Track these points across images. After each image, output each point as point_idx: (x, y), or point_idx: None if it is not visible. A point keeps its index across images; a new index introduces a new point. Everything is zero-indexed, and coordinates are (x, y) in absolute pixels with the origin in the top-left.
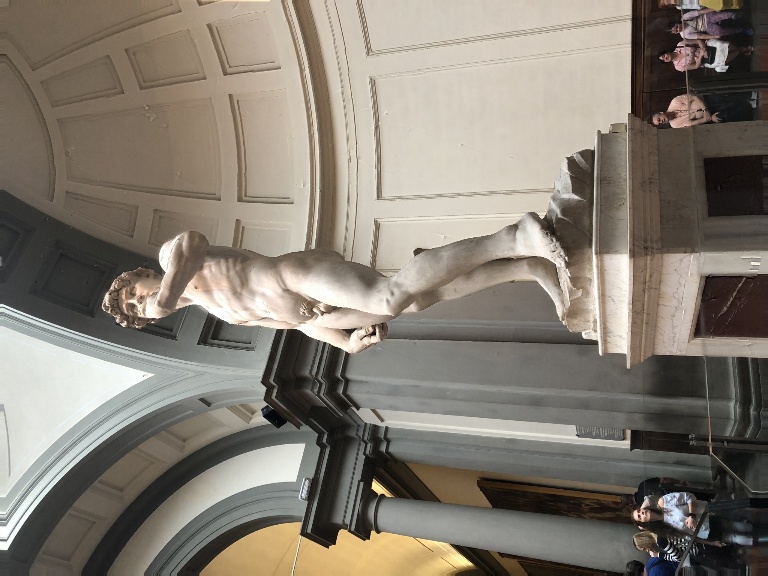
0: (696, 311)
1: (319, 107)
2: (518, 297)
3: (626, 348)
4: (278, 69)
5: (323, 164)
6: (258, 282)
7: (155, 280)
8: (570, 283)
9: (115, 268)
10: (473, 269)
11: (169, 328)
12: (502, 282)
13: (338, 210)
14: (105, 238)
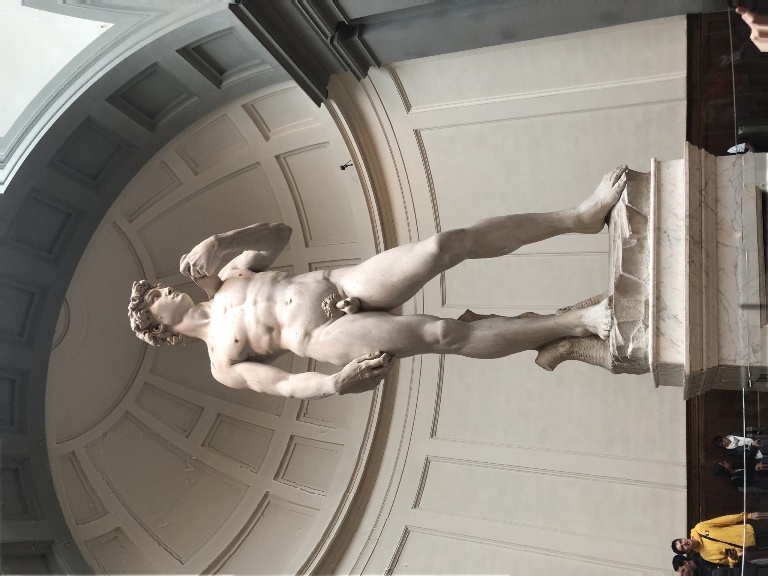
0: (761, 258)
1: (343, 531)
2: None
3: (684, 348)
4: (323, 495)
5: None
6: (303, 276)
7: None
8: (626, 214)
9: (39, 519)
10: None
11: None
12: (543, 327)
13: None
14: None
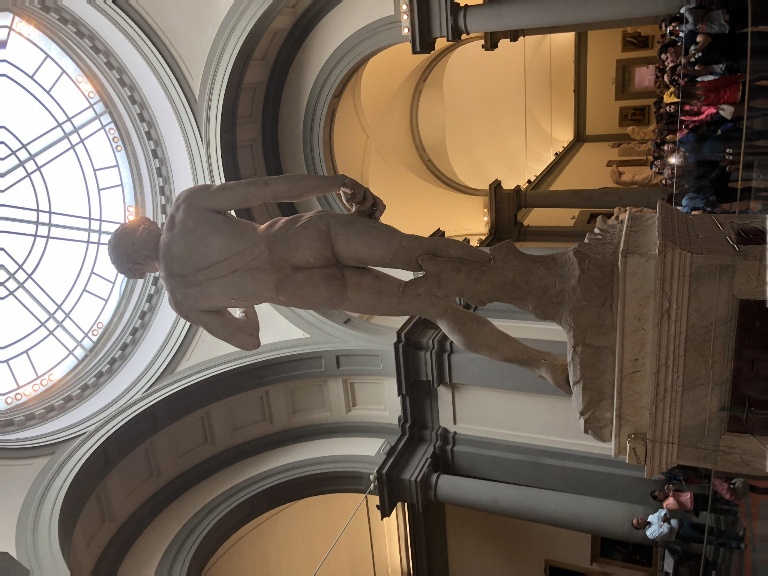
0: None
1: None
2: None
3: None
4: None
5: None
6: None
7: (146, 266)
8: None
9: None
10: None
11: None
12: None
13: None
14: None
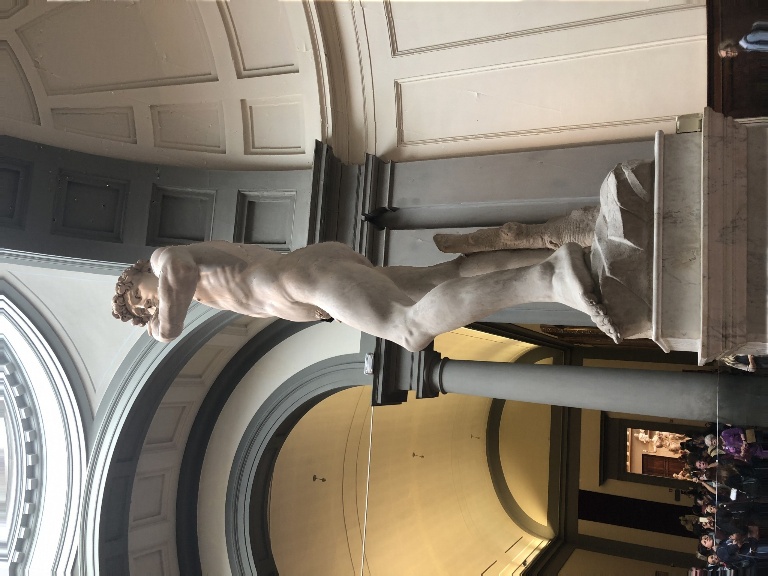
0: None
1: None
2: (570, 167)
3: None
4: None
5: (323, 21)
6: (263, 294)
7: None
8: None
9: (128, 184)
10: (506, 261)
11: (200, 237)
12: None
13: (351, 74)
14: (108, 152)
